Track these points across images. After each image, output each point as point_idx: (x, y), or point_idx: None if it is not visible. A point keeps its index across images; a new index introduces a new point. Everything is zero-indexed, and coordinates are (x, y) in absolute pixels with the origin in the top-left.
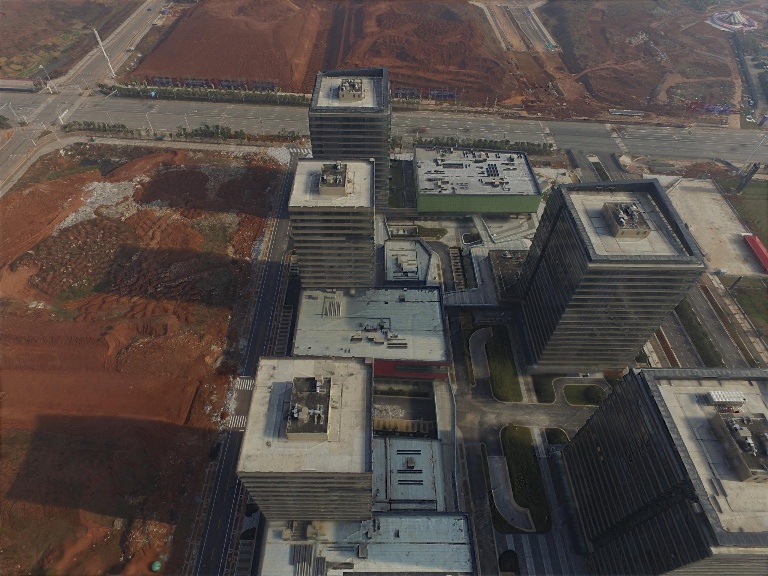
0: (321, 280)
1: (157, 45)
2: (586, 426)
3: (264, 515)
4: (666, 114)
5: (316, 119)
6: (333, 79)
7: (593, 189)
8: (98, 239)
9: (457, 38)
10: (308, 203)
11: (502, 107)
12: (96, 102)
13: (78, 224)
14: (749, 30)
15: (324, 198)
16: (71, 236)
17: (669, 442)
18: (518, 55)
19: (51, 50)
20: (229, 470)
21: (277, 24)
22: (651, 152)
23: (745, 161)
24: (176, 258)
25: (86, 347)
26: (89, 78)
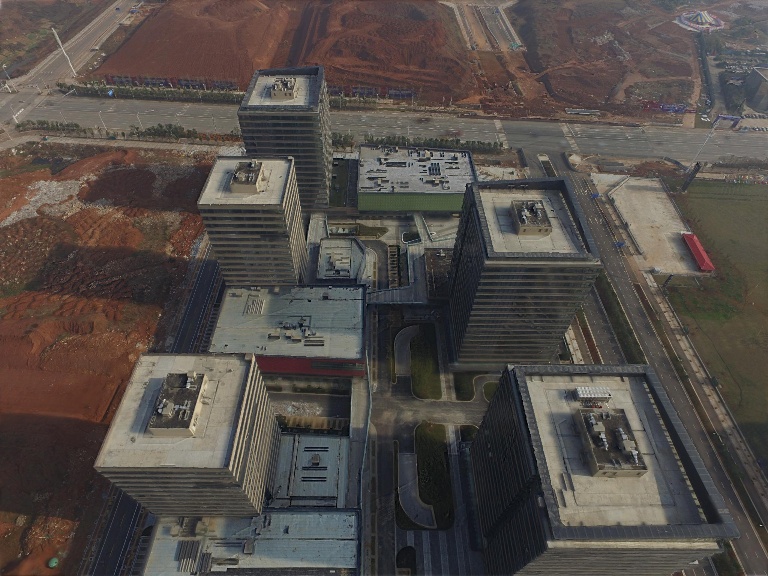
0: (244, 278)
1: (122, 44)
2: (483, 423)
3: None
4: (622, 113)
5: (246, 118)
6: (269, 78)
7: (505, 187)
8: (35, 237)
9: (419, 38)
10: (218, 201)
11: (459, 106)
12: (54, 101)
13: (18, 223)
14: (715, 30)
15: (235, 196)
16: (9, 234)
17: (528, 437)
18: (482, 55)
19: (16, 49)
20: None
21: (241, 23)
22: (602, 151)
23: None
24: (112, 256)
25: (10, 345)
26: (50, 77)
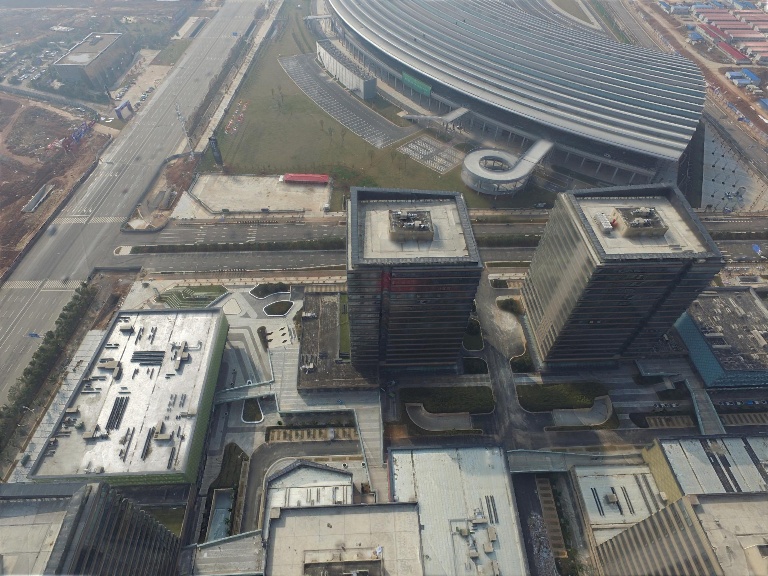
0: None
1: None
2: (564, 328)
3: None
4: (63, 169)
5: None
6: None
7: None
8: None
9: None
10: None
11: None
12: None
13: None
14: None
15: None
16: None
17: (656, 262)
18: None
19: None
20: None
21: None
22: (132, 200)
23: (176, 145)
24: None
25: None
26: None
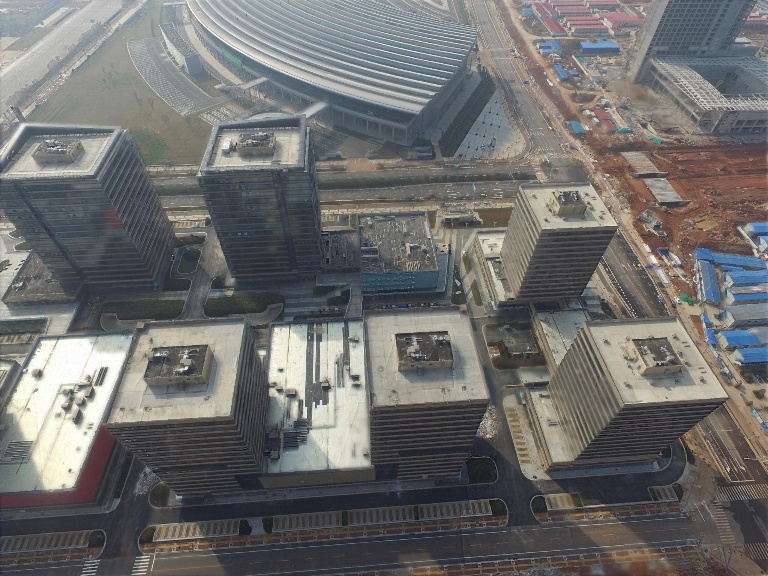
0: None
1: None
2: (221, 241)
3: (258, 467)
4: None
5: None
6: None
7: (6, 161)
8: None
9: None
10: None
11: None
12: None
13: None
14: None
15: None
16: None
17: (249, 172)
18: None
19: None
20: (199, 569)
21: None
22: None
23: None
24: None
25: None
26: None
